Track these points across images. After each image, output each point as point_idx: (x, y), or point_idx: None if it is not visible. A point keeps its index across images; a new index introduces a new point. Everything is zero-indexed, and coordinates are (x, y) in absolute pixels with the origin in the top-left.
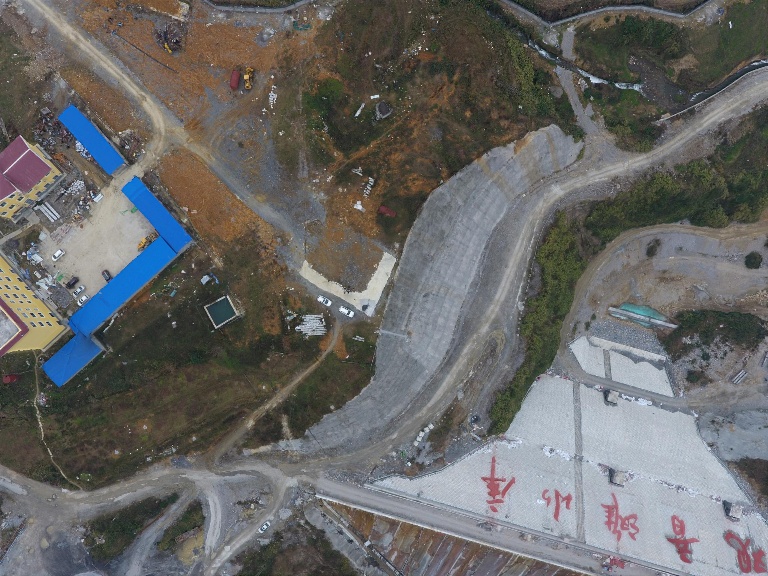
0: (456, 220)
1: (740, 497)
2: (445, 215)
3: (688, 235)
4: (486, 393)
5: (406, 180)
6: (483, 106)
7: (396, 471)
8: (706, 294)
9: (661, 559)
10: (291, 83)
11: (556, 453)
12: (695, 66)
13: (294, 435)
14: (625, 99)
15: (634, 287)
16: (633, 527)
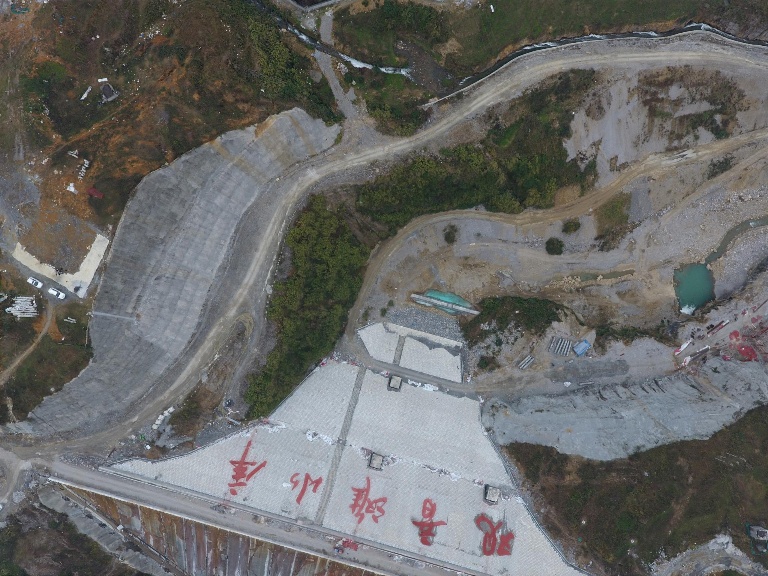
0: (193, 203)
1: (504, 481)
2: (173, 198)
3: (483, 221)
4: (238, 377)
5: (124, 162)
6: (213, 89)
7: (135, 454)
8: (511, 281)
9: (399, 541)
10: (8, 66)
11: (319, 437)
12: (458, 50)
13: (16, 417)
14: (390, 83)
15: (436, 274)
16: (379, 510)
